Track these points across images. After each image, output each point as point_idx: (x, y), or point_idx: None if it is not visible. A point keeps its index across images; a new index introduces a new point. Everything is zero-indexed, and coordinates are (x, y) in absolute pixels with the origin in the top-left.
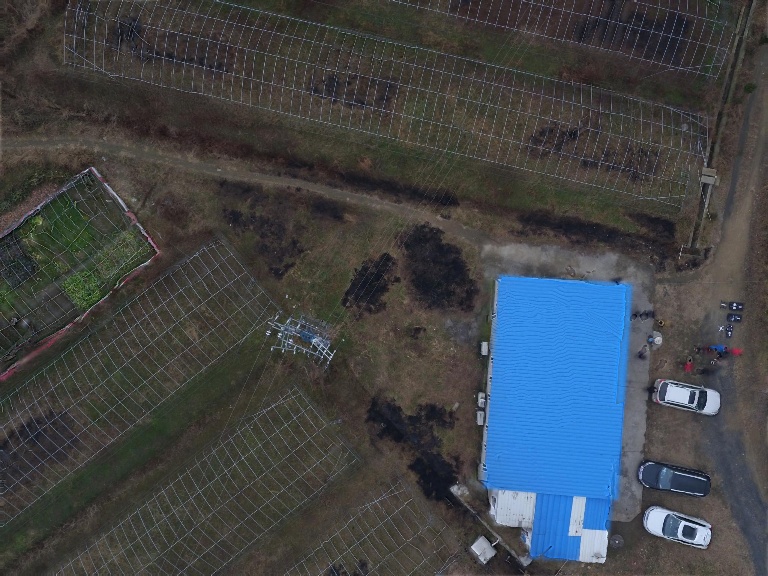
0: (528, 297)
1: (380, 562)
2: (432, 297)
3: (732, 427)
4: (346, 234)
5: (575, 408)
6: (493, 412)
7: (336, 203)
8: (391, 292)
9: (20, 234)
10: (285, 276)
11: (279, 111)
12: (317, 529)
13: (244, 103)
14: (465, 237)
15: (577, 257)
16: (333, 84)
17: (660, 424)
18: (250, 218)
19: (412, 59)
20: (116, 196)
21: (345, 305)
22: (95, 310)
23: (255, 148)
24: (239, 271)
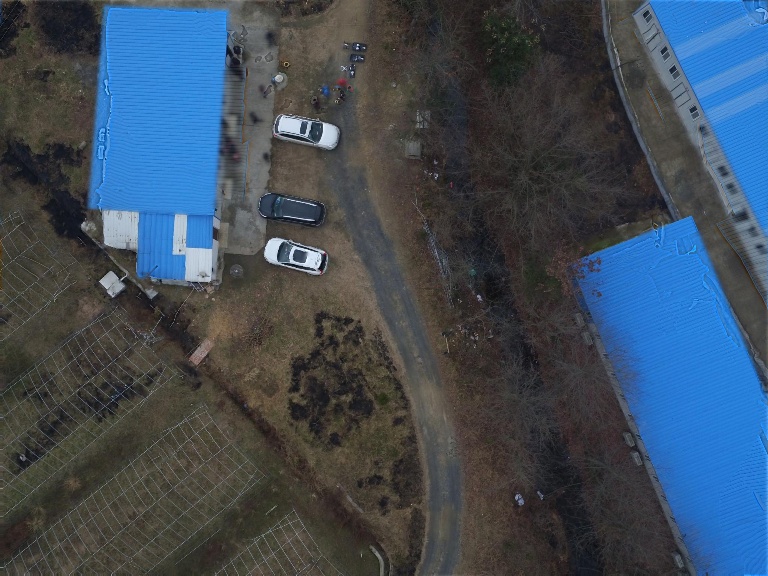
0: (134, 26)
1: None
2: (62, 42)
3: (355, 163)
4: None
5: (203, 148)
6: (114, 147)
7: None
8: (21, 37)
9: None
10: None
11: None
12: None
13: None
14: None
15: (204, 2)
16: None
17: (285, 161)
18: None
19: None
20: None
21: None
22: None
23: None
24: None
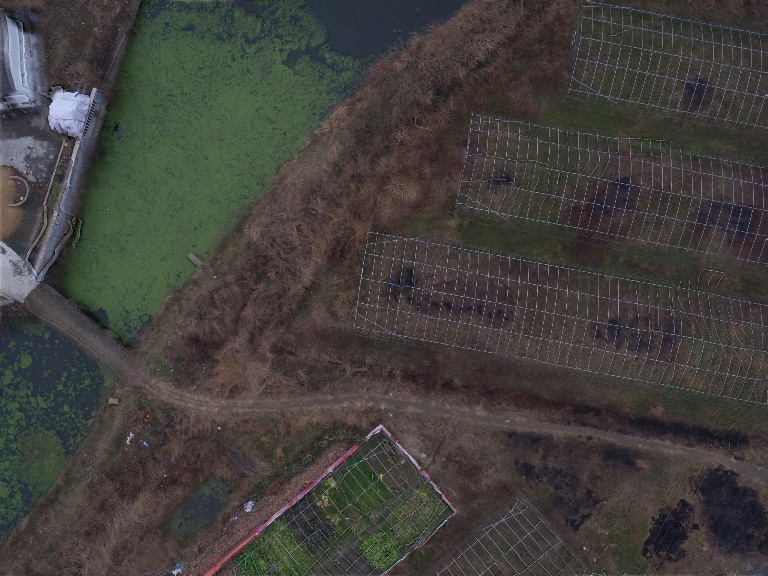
0: None
1: None
2: (731, 542)
3: None
4: (641, 482)
5: None
6: None
7: (628, 450)
8: (690, 539)
9: (313, 497)
10: (581, 527)
11: (576, 367)
12: None
13: (540, 361)
14: (760, 478)
15: None
16: (636, 343)
17: None
18: (543, 470)
19: None
20: (407, 454)
21: (645, 555)
22: (393, 571)
23: (543, 397)
24: (553, 540)
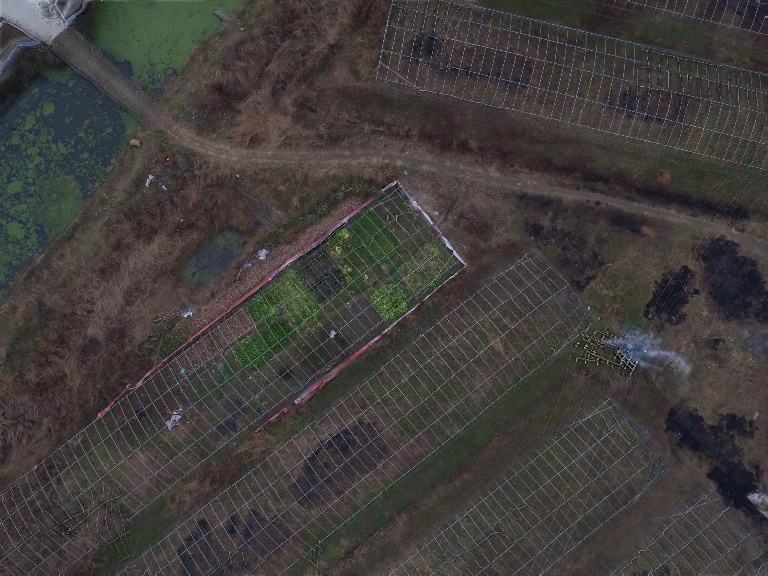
0: None
1: (704, 570)
2: (729, 309)
3: None
4: (646, 247)
5: None
6: None
7: (634, 217)
8: (691, 304)
9: (327, 247)
10: (587, 288)
11: (587, 126)
12: (630, 538)
13: (554, 119)
14: (759, 250)
15: None
16: (647, 101)
17: None
18: (551, 231)
19: (715, 76)
20: (421, 209)
21: (647, 317)
22: (402, 322)
23: (554, 162)
24: (561, 284)
